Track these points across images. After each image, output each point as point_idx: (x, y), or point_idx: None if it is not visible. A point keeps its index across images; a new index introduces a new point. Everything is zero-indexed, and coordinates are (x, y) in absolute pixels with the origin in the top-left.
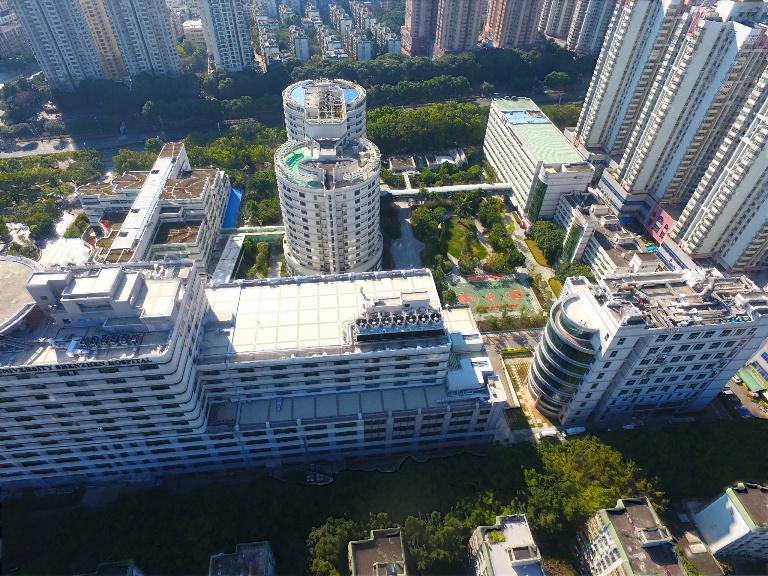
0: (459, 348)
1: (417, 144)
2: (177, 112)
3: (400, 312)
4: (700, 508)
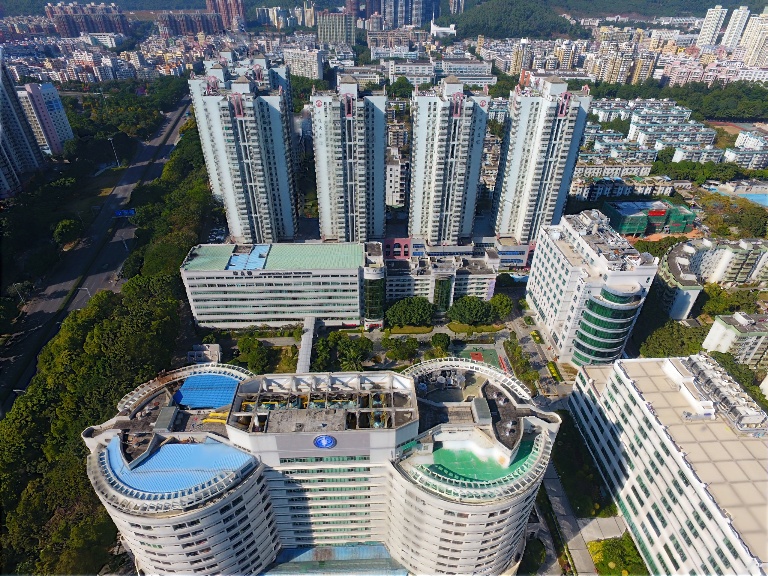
0: None
1: None
2: None
3: None
4: None
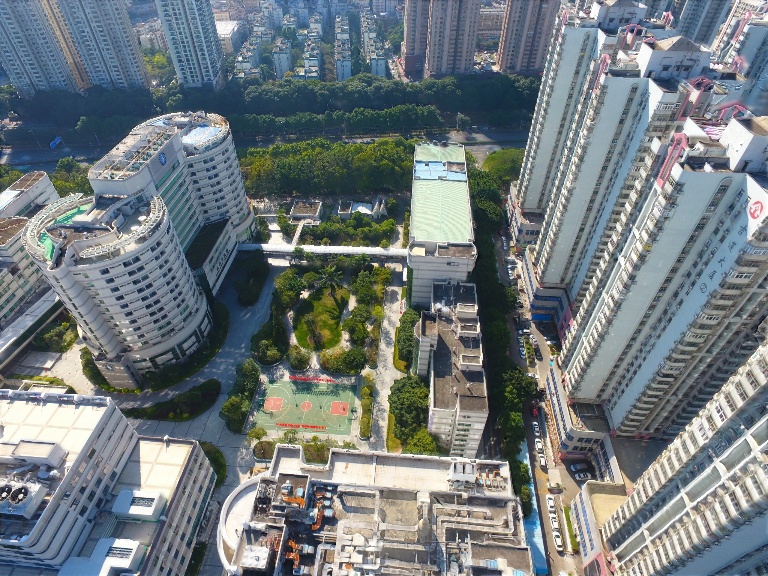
0: (124, 514)
1: (334, 187)
2: (108, 130)
3: (18, 465)
4: None
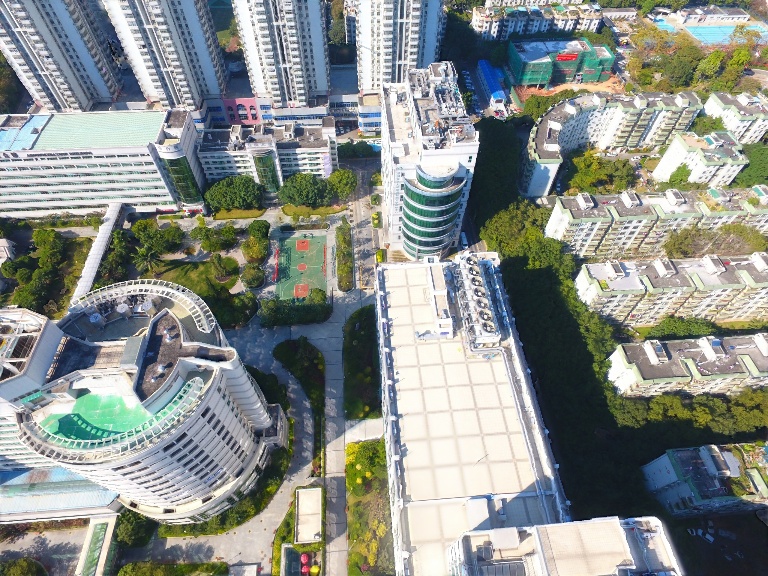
0: None
1: None
2: None
3: None
4: (522, 190)
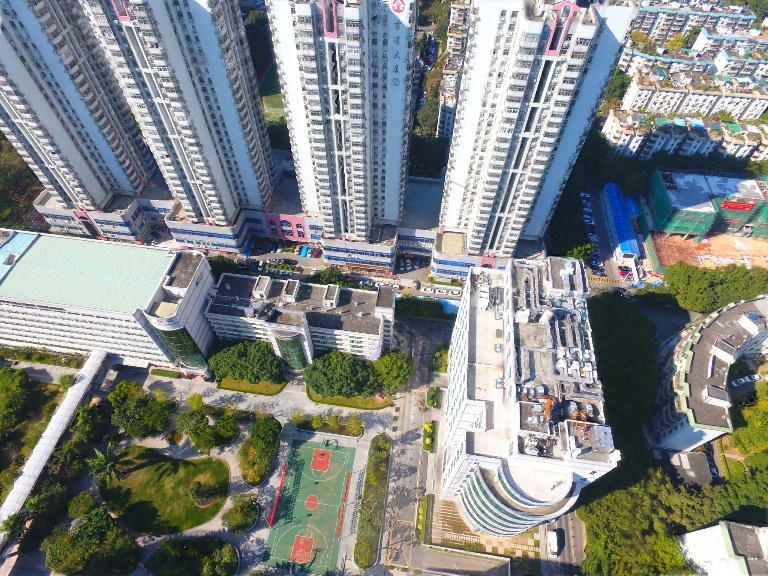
0: None
1: None
2: None
3: None
4: (652, 435)
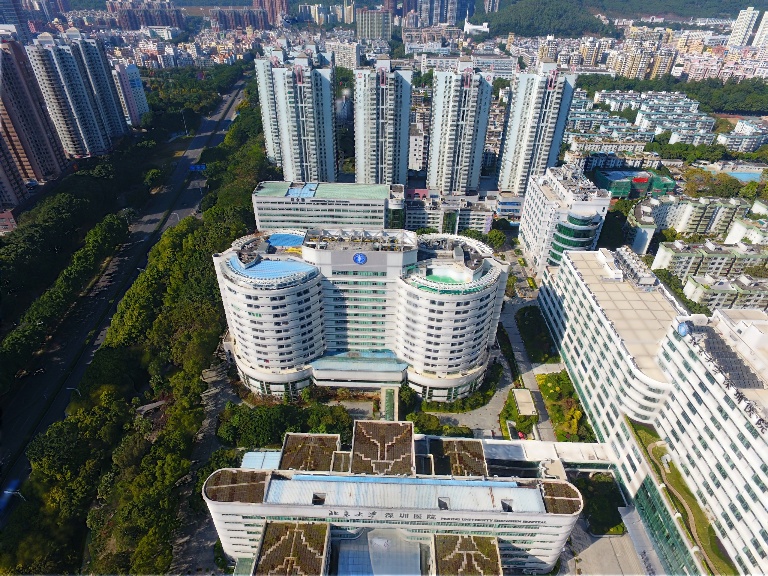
0: None
1: None
2: None
3: None
4: None
